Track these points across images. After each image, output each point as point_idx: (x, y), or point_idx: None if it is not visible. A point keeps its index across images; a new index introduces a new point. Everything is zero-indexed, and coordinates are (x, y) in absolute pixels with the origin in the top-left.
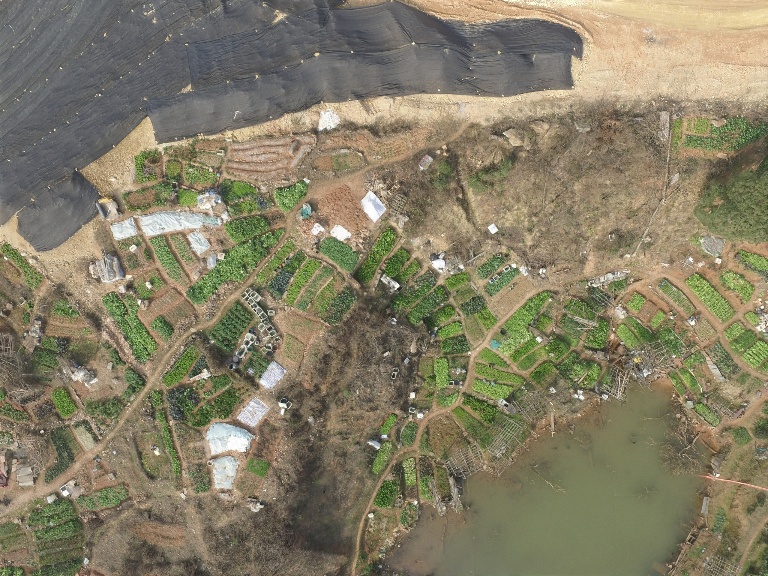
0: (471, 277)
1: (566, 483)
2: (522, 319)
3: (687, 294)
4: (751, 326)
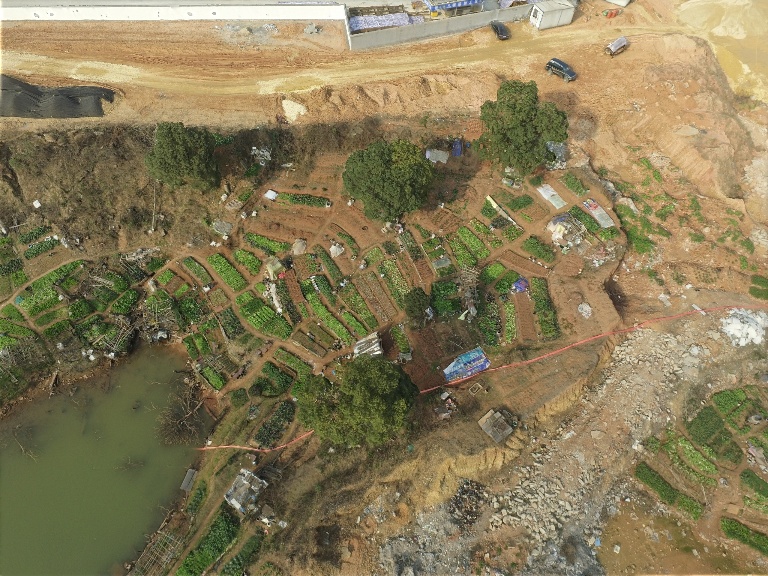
0: (14, 243)
1: (46, 453)
2: (49, 279)
3: (207, 269)
4: (261, 295)
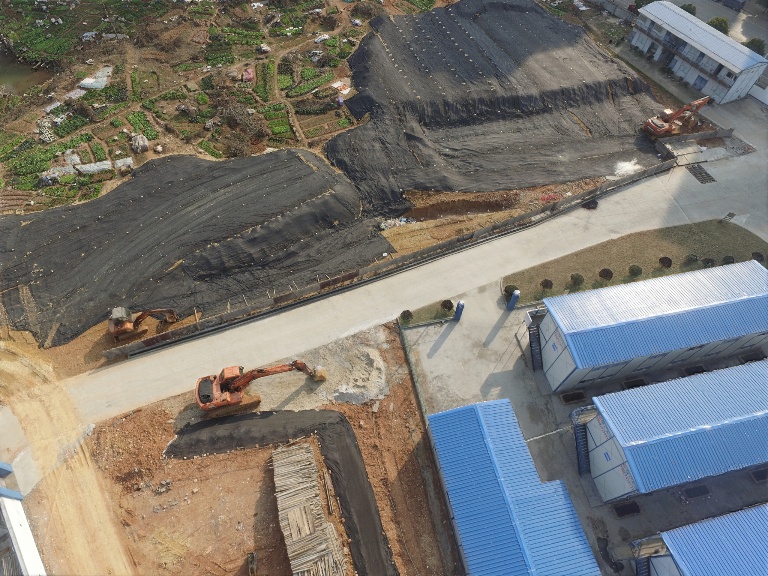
0: None
1: None
2: None
3: None
4: None
